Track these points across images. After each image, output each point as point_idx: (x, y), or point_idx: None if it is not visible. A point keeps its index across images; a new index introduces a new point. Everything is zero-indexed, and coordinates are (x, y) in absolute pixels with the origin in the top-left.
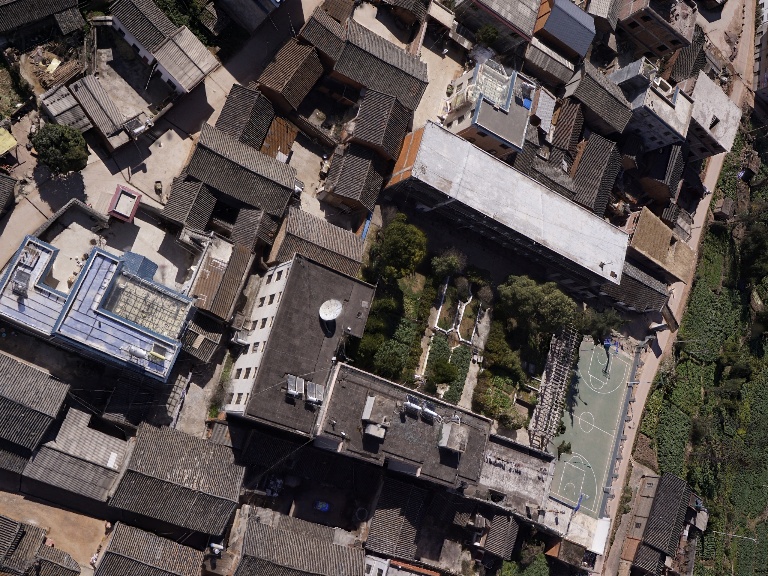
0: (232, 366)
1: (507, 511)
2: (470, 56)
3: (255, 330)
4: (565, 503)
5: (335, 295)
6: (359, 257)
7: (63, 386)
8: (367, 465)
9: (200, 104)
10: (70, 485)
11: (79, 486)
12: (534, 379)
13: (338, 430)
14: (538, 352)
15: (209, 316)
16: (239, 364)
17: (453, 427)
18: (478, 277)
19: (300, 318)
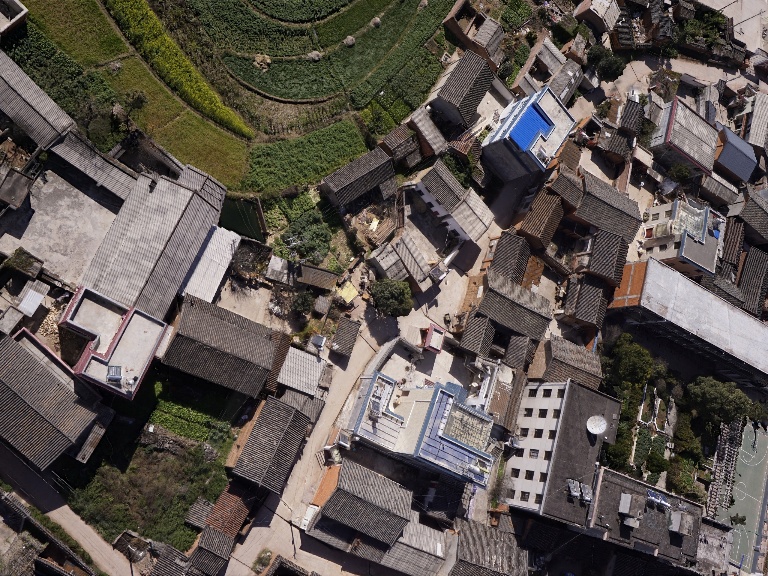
0: (504, 464)
1: (700, 575)
2: (659, 186)
3: (528, 437)
4: (734, 564)
5: (596, 411)
6: (600, 373)
7: (408, 493)
8: (603, 542)
9: (471, 246)
10: (411, 570)
11: (416, 571)
12: (708, 459)
13: (604, 522)
14: (710, 436)
15: (495, 427)
16: (514, 464)
17: (683, 516)
18: (673, 378)
19: (574, 432)
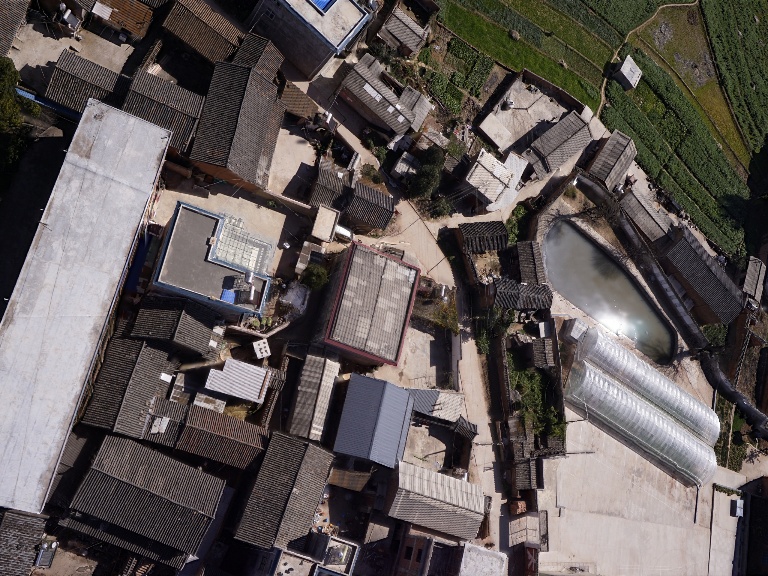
0: None
1: None
2: (291, 285)
3: None
4: None
5: None
6: None
7: None
8: None
9: None
10: None
11: None
12: None
13: None
14: None
15: None
16: None
17: None
18: None
19: None
